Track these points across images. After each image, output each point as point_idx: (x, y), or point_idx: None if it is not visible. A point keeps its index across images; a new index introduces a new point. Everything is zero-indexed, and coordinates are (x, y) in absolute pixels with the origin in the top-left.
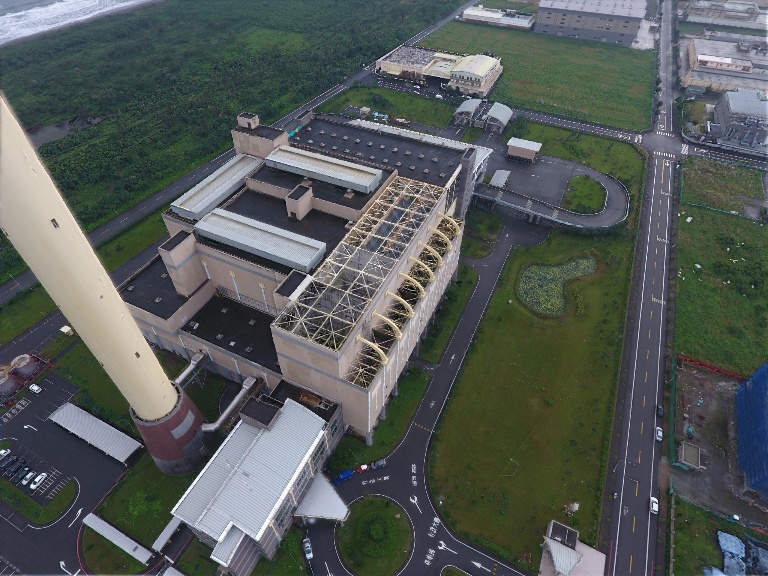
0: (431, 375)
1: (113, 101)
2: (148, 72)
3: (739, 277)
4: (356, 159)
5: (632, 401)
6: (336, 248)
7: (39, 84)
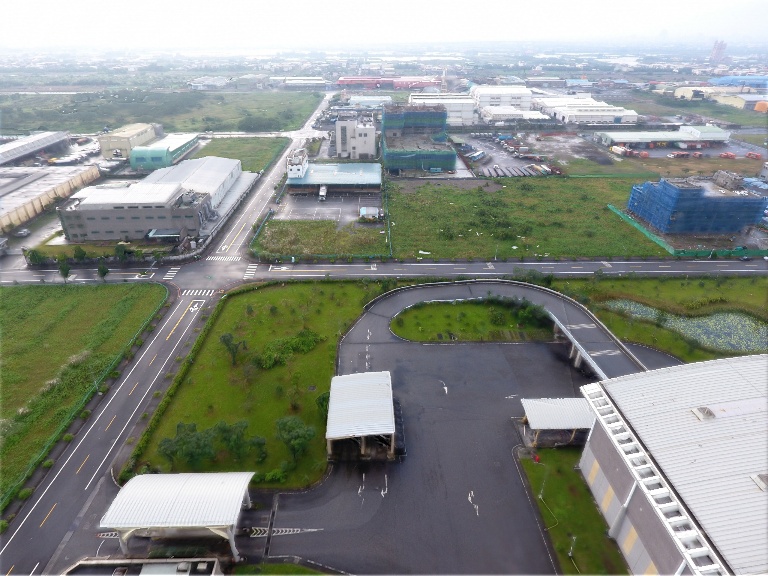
0: None
1: None
2: None
3: (509, 230)
4: None
5: (764, 270)
6: None
7: None
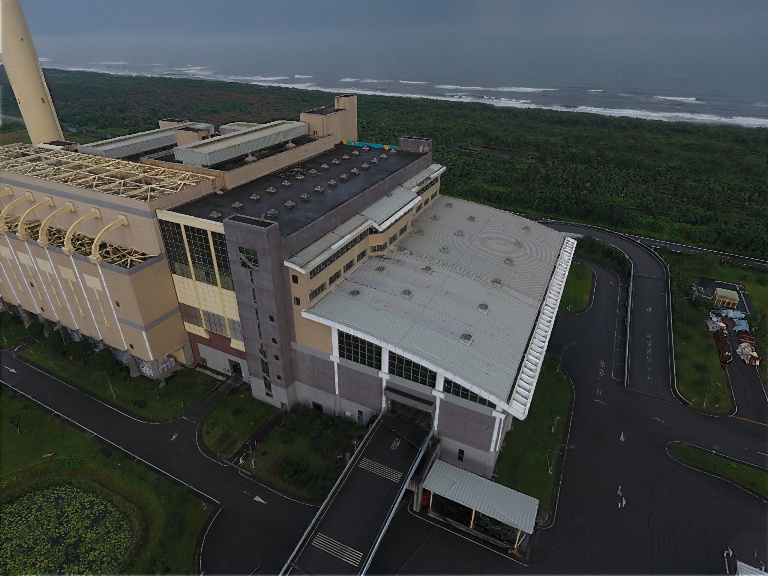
0: (7, 348)
1: (577, 159)
2: (667, 162)
3: None
4: (271, 156)
5: None
6: (92, 155)
7: (577, 135)
